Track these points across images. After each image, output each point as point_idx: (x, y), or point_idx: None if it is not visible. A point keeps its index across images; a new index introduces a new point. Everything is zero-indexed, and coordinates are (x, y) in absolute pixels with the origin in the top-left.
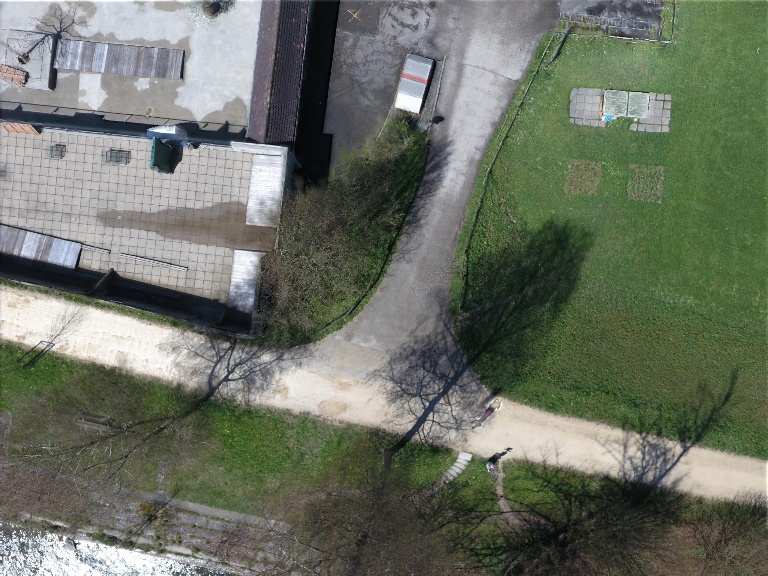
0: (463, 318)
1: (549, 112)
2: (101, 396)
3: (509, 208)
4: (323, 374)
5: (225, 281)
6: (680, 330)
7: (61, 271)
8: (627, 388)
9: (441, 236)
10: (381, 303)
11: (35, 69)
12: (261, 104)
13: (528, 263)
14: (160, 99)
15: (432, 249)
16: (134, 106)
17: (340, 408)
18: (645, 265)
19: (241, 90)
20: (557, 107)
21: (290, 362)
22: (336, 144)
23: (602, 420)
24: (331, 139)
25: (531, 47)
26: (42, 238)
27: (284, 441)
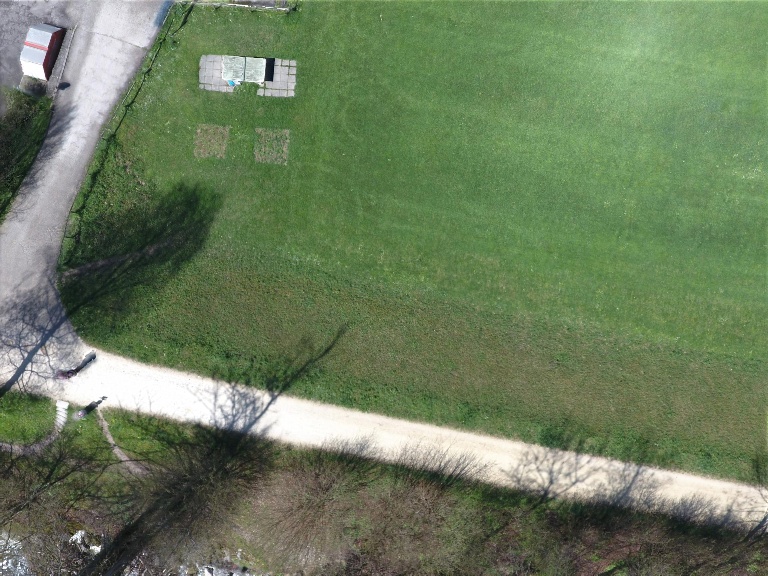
0: (70, 274)
1: (177, 78)
2: None
3: (136, 170)
4: None
5: None
6: (300, 287)
7: None
8: (226, 340)
9: (56, 196)
10: None
11: None
12: None
13: (155, 223)
14: None
15: (45, 209)
16: None
17: None
18: (273, 225)
19: None
20: (186, 73)
21: None
22: None
23: (193, 370)
24: None
25: (160, 16)
26: None
27: None
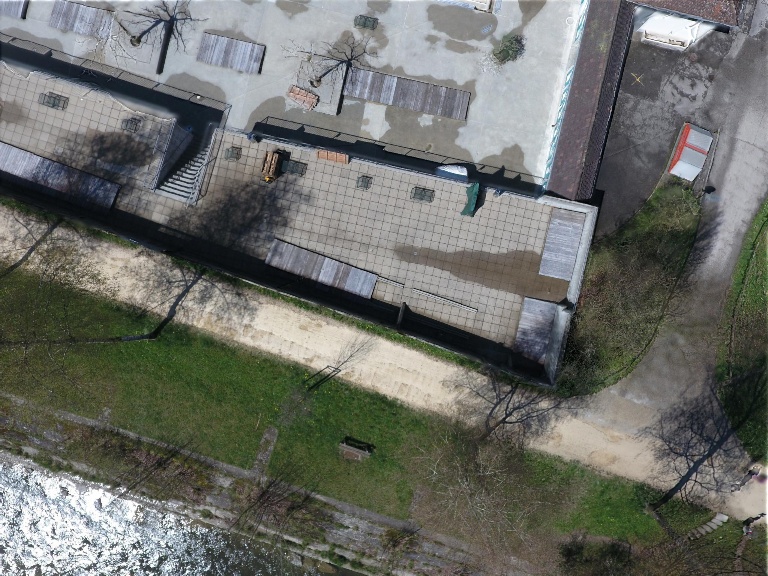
0: (726, 384)
1: None
2: (372, 424)
3: (765, 281)
4: (597, 426)
5: (512, 326)
6: None
7: (356, 300)
8: None
9: (709, 303)
10: (653, 362)
11: (326, 94)
12: (572, 161)
13: None
14: (441, 137)
15: (701, 315)
16: (415, 141)
17: (609, 460)
18: None
19: (521, 138)
20: None
21: (566, 411)
22: (606, 200)
23: None
24: (603, 195)
25: None
26: (340, 265)
27: (545, 485)
